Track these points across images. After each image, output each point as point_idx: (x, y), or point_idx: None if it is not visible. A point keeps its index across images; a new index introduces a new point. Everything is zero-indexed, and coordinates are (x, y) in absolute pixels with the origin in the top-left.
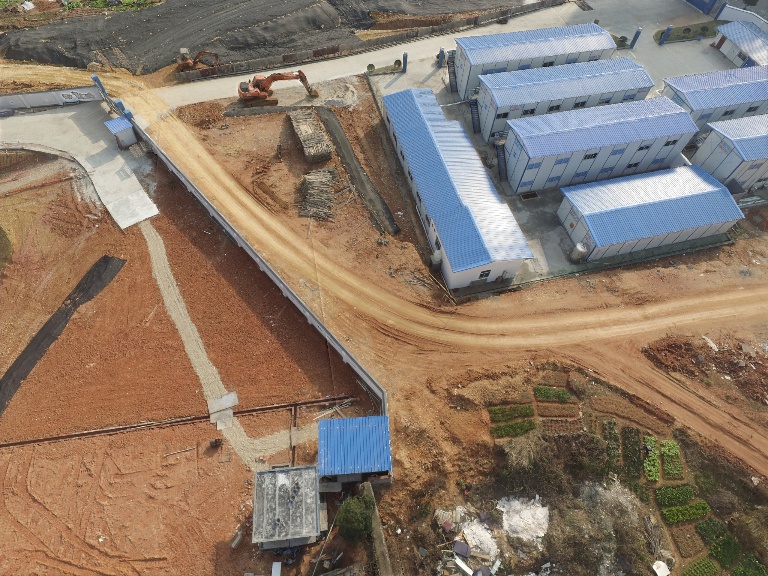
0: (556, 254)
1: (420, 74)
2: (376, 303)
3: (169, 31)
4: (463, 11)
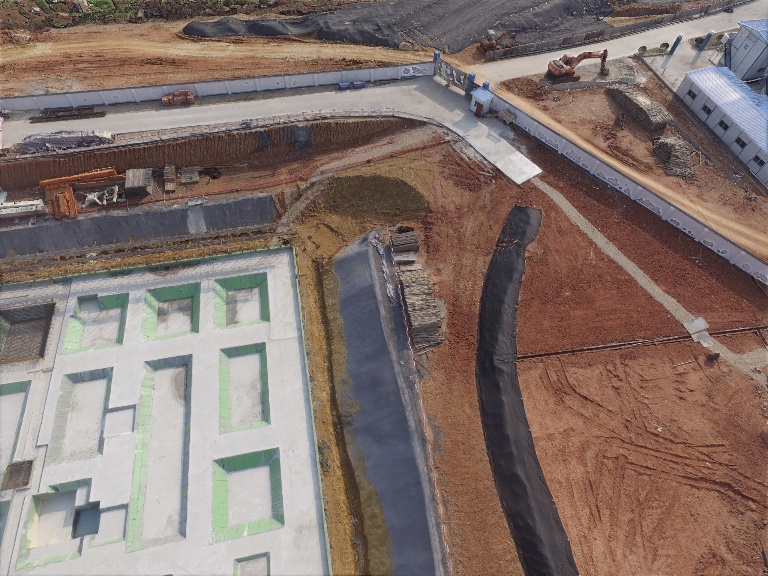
0: None
1: (687, 56)
2: None
3: (452, 15)
4: (688, 1)
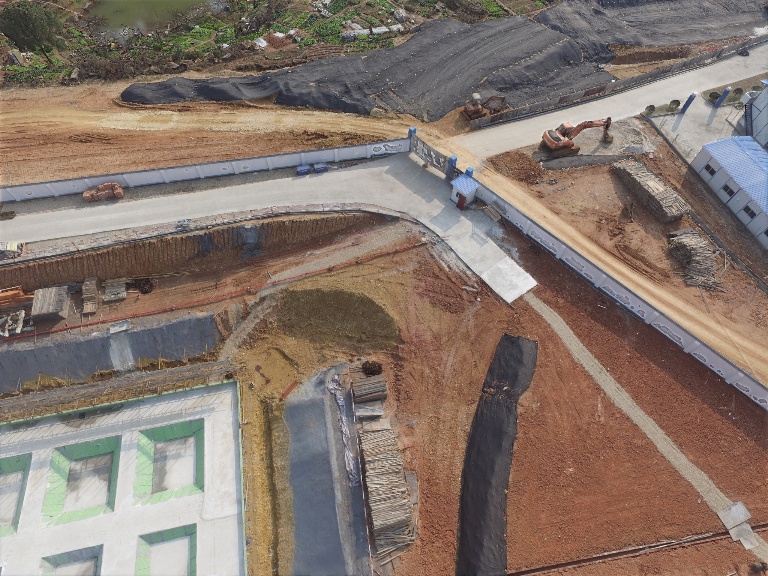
0: None
1: (700, 115)
2: None
3: (432, 71)
4: (698, 42)
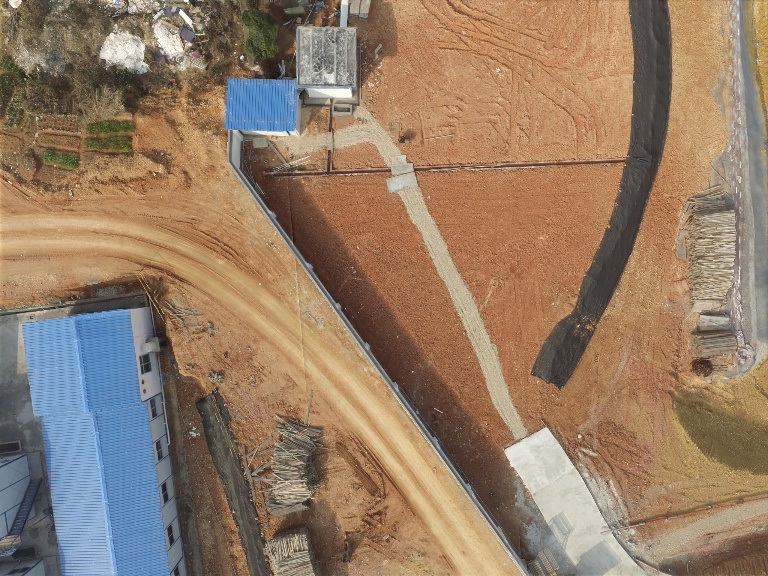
0: (3, 348)
1: None
2: (235, 288)
3: None
4: None
